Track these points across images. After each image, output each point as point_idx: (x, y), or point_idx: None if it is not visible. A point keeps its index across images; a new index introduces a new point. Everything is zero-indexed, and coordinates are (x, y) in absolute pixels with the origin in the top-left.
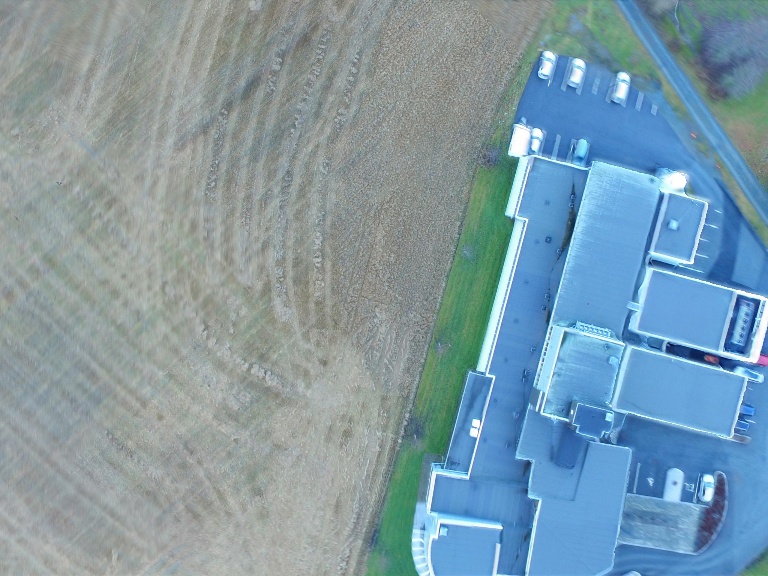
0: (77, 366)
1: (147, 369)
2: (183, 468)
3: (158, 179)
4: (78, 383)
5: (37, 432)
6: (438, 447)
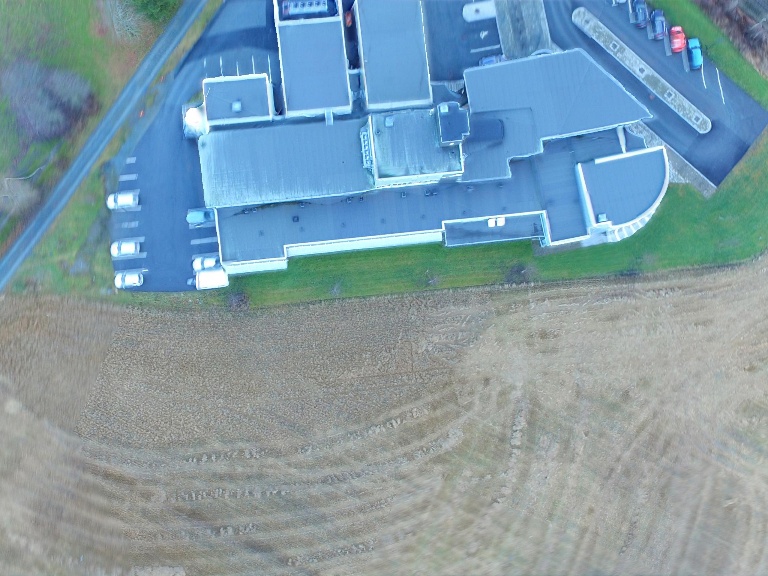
0: None
1: (552, 540)
2: (629, 472)
3: None
4: None
5: None
6: (525, 247)
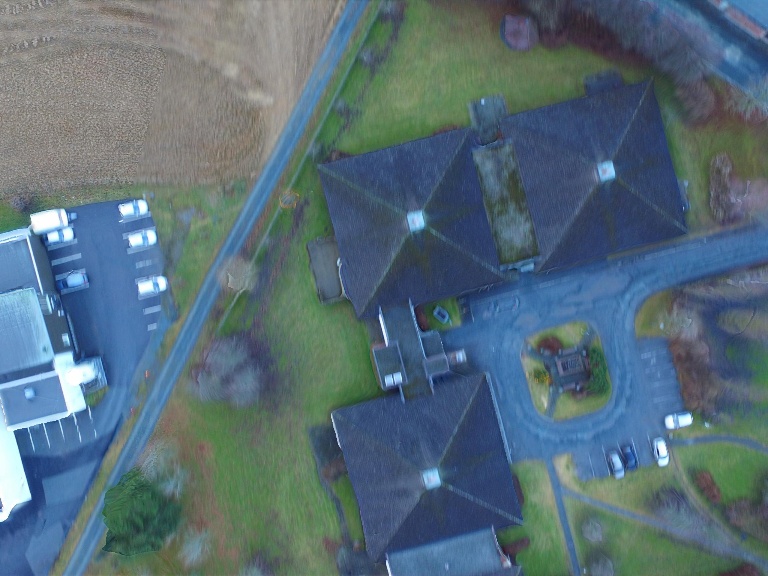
0: None
1: None
2: None
3: None
4: None
5: None
6: None
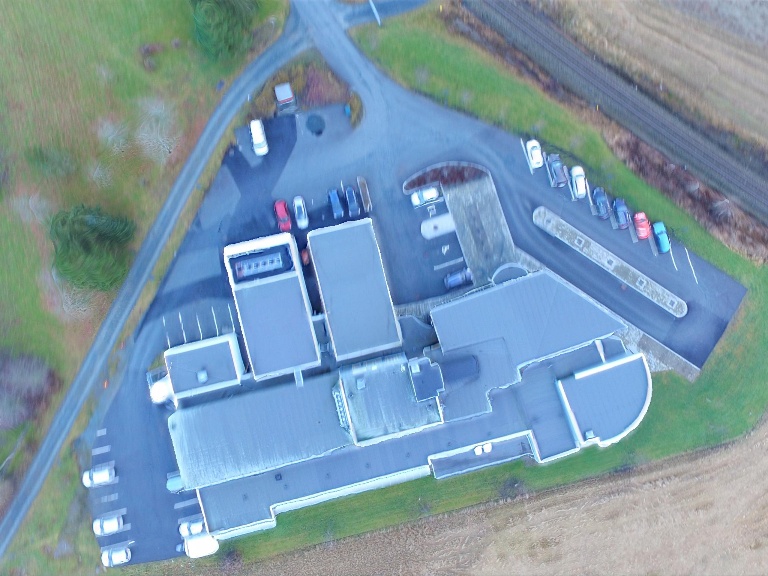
0: None
1: None
2: None
3: None
4: None
5: None
6: None
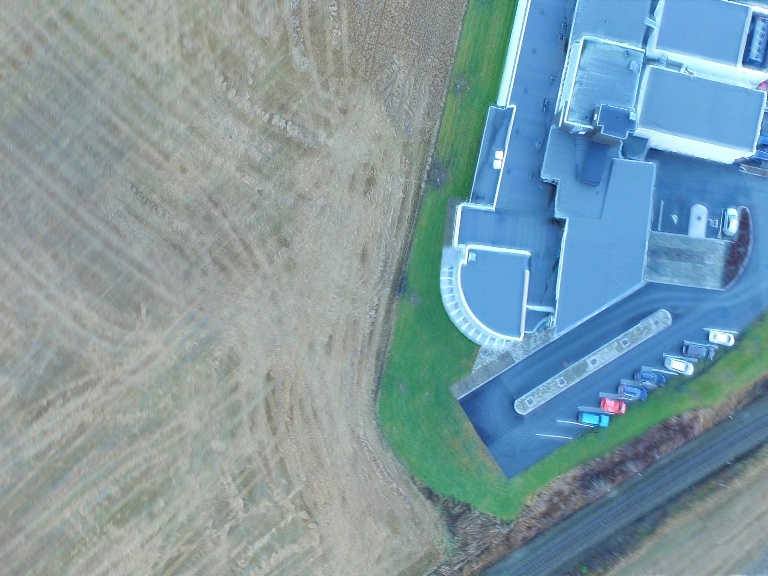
0: (98, 120)
1: (168, 122)
2: (208, 221)
3: None
4: (100, 137)
5: (61, 187)
6: (462, 191)
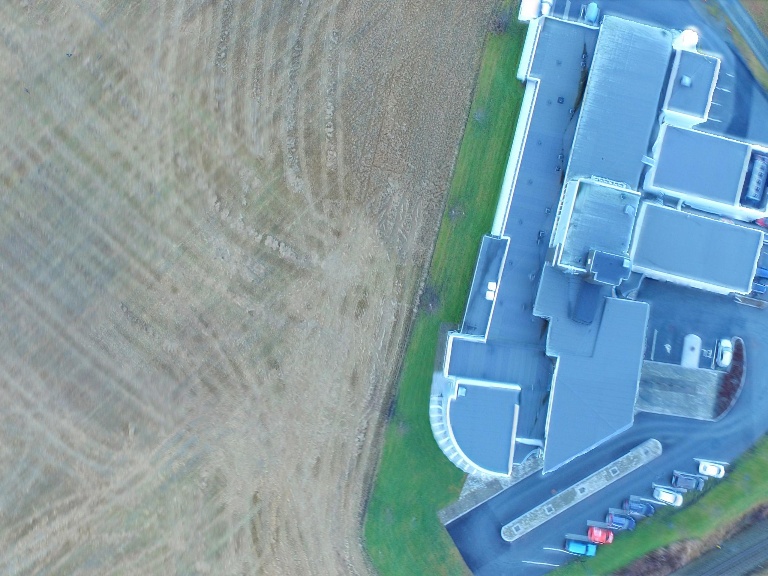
0: (90, 239)
1: (160, 242)
2: (198, 341)
3: (168, 50)
4: (92, 256)
5: (51, 305)
6: (454, 316)
